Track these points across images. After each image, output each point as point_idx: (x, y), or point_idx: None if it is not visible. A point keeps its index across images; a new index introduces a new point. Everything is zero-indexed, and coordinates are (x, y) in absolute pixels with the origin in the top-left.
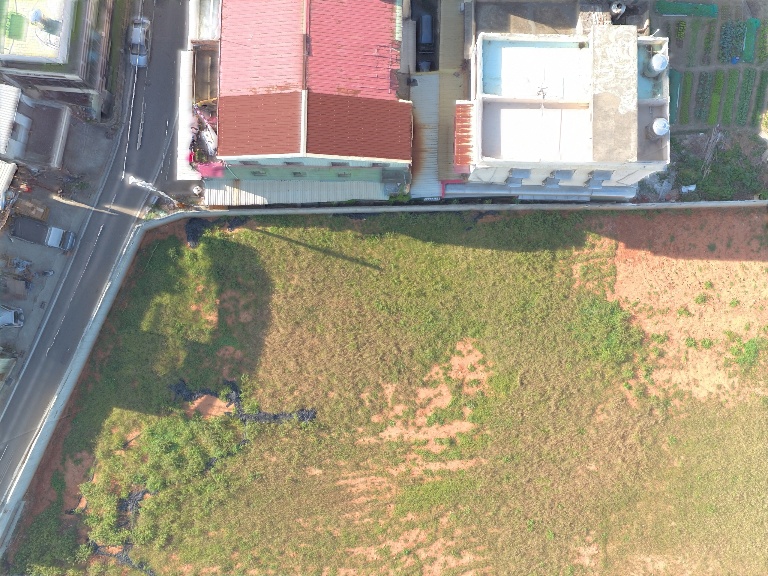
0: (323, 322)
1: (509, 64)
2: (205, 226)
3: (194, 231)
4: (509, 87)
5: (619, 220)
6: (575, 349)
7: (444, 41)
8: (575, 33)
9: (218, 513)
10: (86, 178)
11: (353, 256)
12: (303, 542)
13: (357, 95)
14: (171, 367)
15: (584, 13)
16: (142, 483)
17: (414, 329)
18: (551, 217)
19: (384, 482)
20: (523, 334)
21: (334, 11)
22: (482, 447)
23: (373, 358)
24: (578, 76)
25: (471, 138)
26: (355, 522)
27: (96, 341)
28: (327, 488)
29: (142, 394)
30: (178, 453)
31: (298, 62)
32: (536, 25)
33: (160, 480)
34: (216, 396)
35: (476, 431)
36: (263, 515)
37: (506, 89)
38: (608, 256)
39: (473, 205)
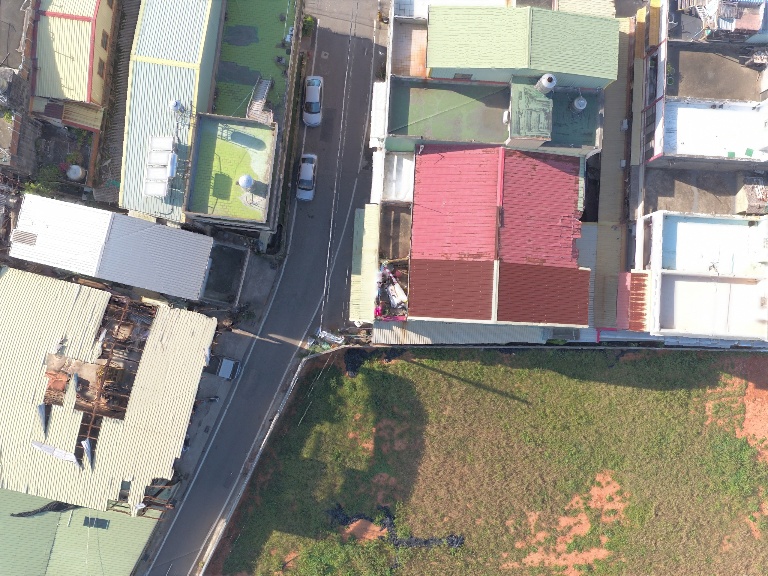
0: (473, 452)
1: (684, 239)
2: (363, 356)
3: (353, 361)
4: (683, 261)
5: (749, 361)
6: (706, 483)
7: (603, 194)
8: (734, 200)
9: None
10: (251, 307)
11: (503, 390)
12: None
13: (542, 264)
14: (329, 492)
15: (748, 186)
16: None
17: (558, 461)
18: (688, 358)
19: None
20: (659, 468)
21: (525, 184)
22: (617, 574)
23: (519, 488)
24: (747, 252)
25: (645, 306)
26: None
27: (256, 464)
28: None
29: (301, 518)
30: (333, 574)
31: (491, 233)
32: (698, 191)
33: None
34: (370, 521)
35: (613, 559)
36: None
37: (680, 263)
38: (738, 395)
39: (620, 347)
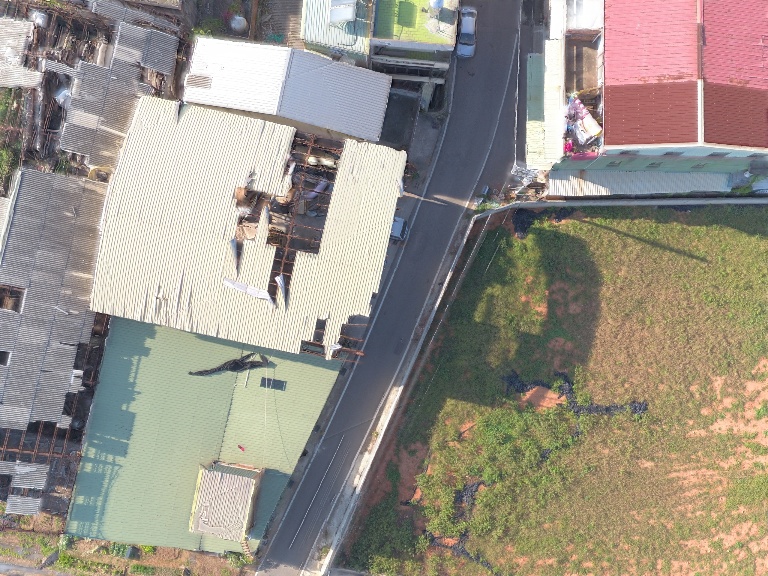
0: (652, 314)
1: None
2: (532, 217)
3: (522, 222)
4: None
5: None
6: None
7: None
8: None
9: (554, 505)
10: None
11: (680, 248)
12: (638, 534)
13: (746, 85)
14: (503, 358)
15: None
16: (478, 474)
17: (743, 321)
18: None
19: (715, 475)
20: None
21: (724, 0)
22: None
23: (703, 350)
24: None
25: None
26: (688, 515)
27: None
28: (661, 480)
29: (476, 385)
30: (511, 444)
31: (692, 51)
32: None
33: (497, 471)
34: (548, 387)
35: None
36: (598, 507)
37: None
38: None
39: None
